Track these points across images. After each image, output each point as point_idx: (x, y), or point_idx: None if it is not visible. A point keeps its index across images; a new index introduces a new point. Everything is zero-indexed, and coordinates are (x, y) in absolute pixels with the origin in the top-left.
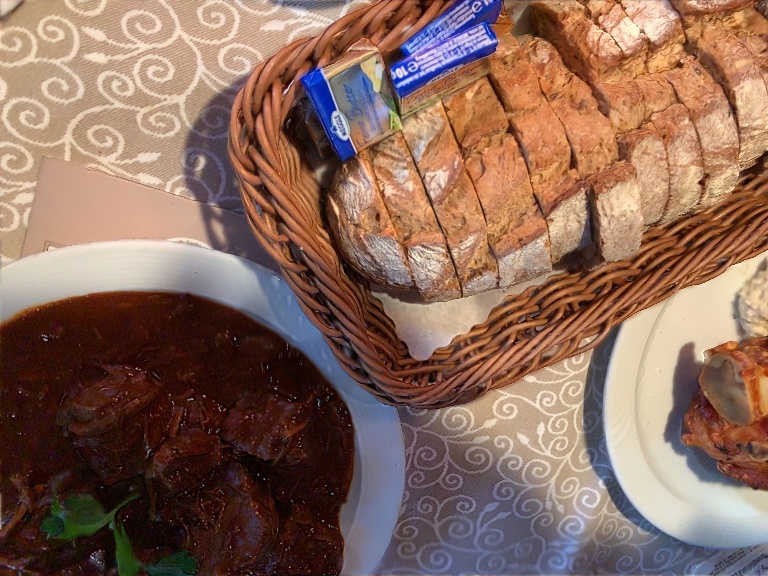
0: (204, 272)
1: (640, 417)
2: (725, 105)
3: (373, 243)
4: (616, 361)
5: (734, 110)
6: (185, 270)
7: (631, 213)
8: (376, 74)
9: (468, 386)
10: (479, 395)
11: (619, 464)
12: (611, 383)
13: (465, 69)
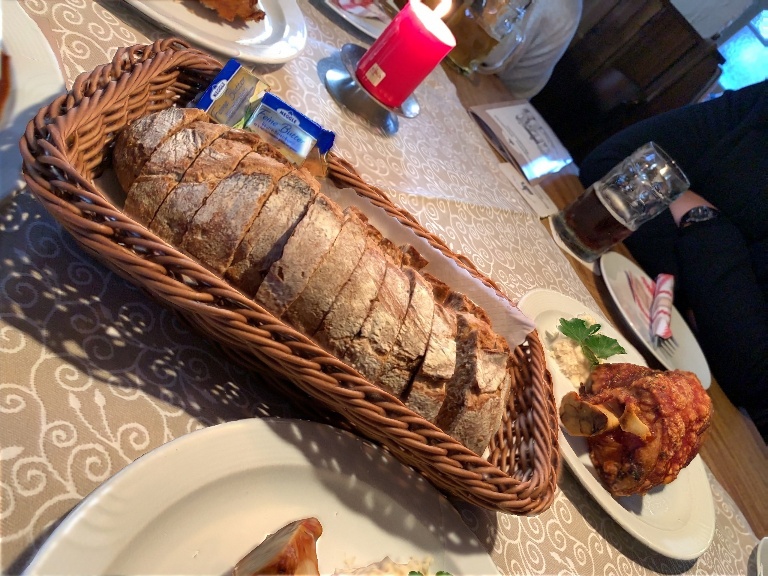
0: (38, 64)
1: (124, 574)
2: (408, 286)
3: (167, 113)
4: (182, 443)
5: (411, 293)
6: (32, 53)
7: (324, 236)
8: (259, 95)
9: (95, 202)
10: (89, 220)
11: (40, 572)
12: (153, 459)
13: (296, 134)
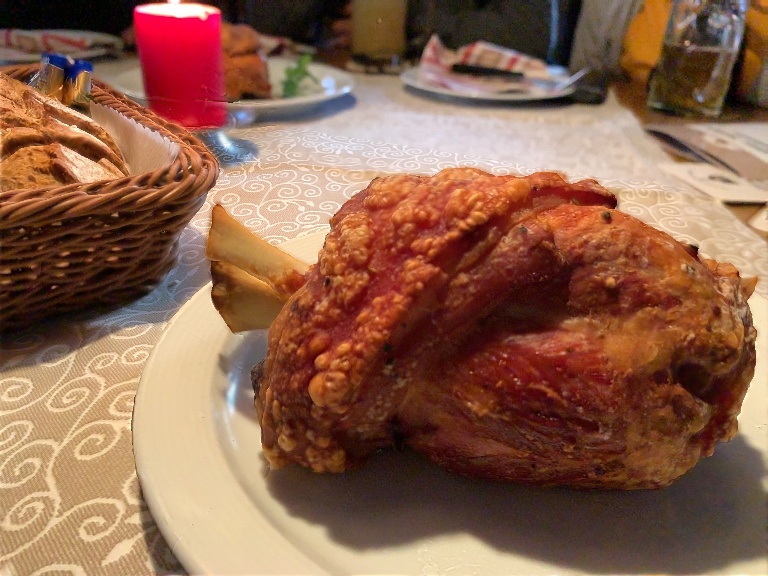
0: None
1: None
2: None
3: None
4: None
5: None
6: None
7: None
8: None
9: None
10: None
11: None
12: None
13: None
